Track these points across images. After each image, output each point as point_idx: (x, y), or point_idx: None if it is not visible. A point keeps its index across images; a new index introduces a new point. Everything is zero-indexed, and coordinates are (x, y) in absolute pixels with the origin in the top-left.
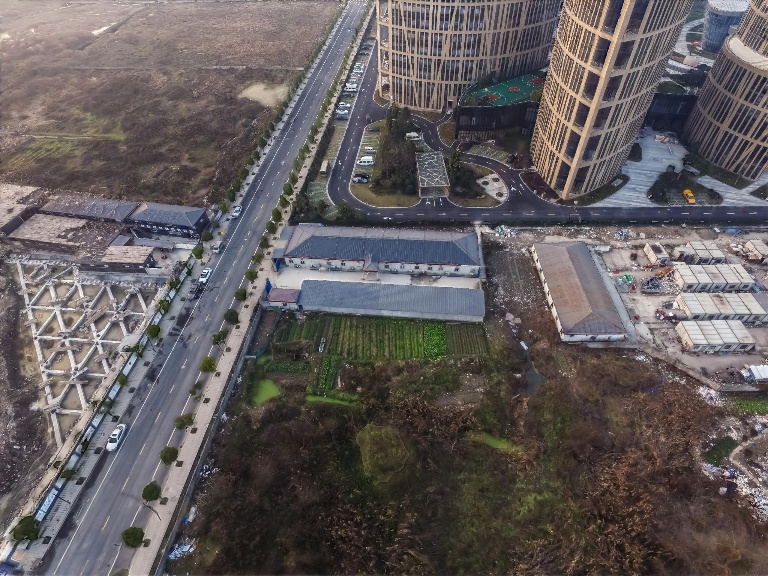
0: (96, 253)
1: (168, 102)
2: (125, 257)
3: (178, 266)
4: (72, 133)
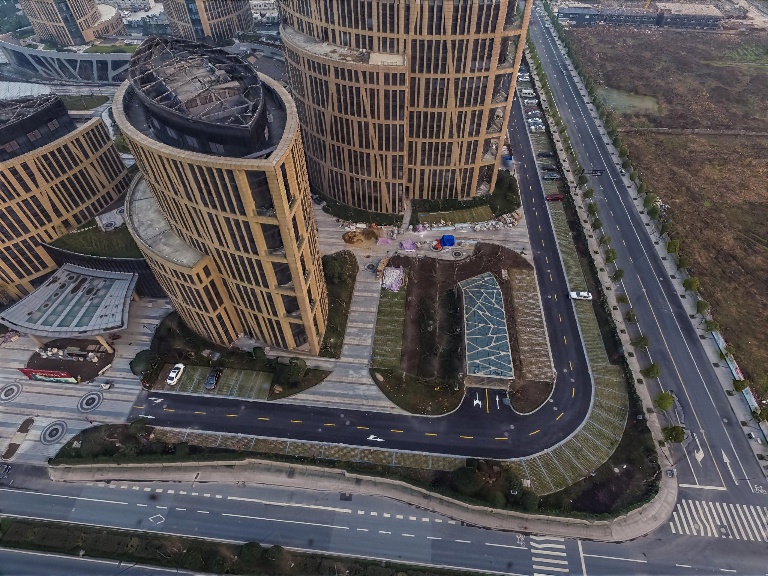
0: (595, 5)
1: (717, 85)
2: (579, 4)
3: (551, 4)
4: (760, 67)
